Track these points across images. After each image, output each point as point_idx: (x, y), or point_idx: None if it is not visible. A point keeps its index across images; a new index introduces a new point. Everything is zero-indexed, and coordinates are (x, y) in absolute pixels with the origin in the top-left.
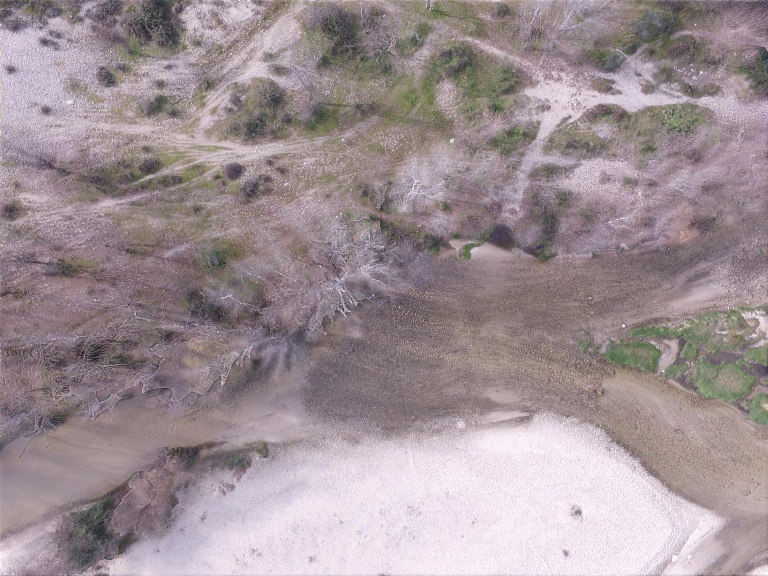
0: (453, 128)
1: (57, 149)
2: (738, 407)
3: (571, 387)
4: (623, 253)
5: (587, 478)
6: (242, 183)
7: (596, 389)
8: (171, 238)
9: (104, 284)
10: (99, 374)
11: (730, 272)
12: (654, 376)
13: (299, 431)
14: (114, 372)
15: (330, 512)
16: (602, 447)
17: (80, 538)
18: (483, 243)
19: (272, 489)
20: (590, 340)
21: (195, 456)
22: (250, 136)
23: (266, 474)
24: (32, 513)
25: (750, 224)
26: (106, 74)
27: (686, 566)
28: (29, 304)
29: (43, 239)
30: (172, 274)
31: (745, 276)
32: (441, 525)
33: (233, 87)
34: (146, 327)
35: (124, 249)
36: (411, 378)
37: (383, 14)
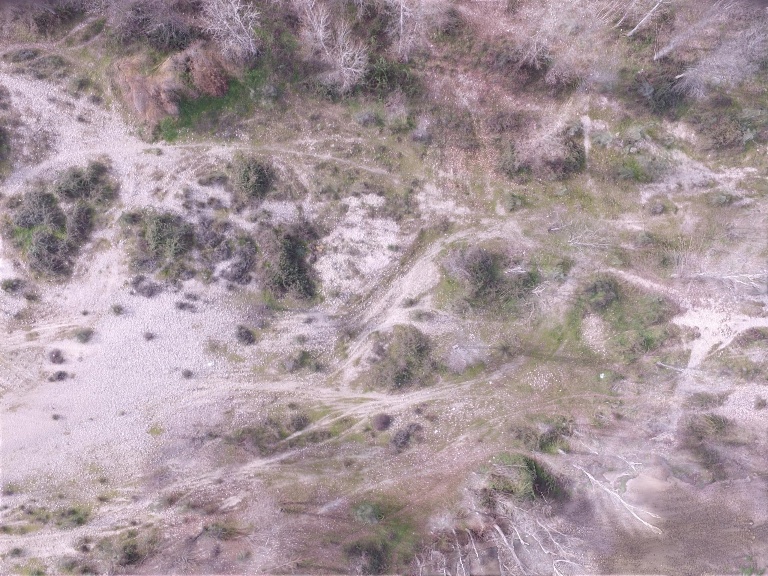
0: (602, 362)
1: (201, 413)
2: None
3: None
4: None
5: None
6: (391, 433)
7: None
8: (323, 494)
9: (259, 545)
10: None
11: None
12: None
13: None
14: None
15: None
16: None
17: None
18: (638, 474)
19: None
20: (753, 565)
21: None
22: (397, 387)
23: None
24: None
25: None
26: (246, 334)
27: None
28: (185, 570)
29: (195, 505)
30: (327, 530)
31: None
32: None
33: (375, 336)
34: None
35: (278, 511)
36: None
37: (523, 251)
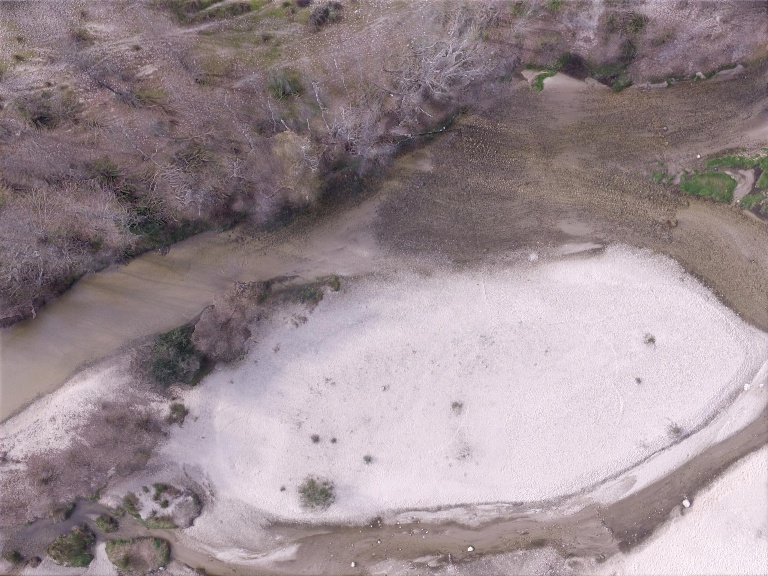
0: None
1: None
2: None
3: (644, 219)
4: (699, 82)
5: (660, 307)
6: (311, 11)
7: (670, 220)
8: (240, 68)
9: (173, 115)
10: None
11: None
12: (728, 207)
13: (370, 265)
14: (197, 176)
15: (403, 342)
16: (675, 278)
17: (162, 353)
18: (556, 73)
19: (344, 321)
20: (664, 171)
21: (266, 290)
22: None
23: (338, 307)
24: (105, 347)
25: None
26: None
27: (758, 394)
28: (98, 136)
29: (111, 69)
30: (241, 105)
31: None
32: (514, 354)
33: None
34: (216, 158)
35: (193, 78)
36: (483, 211)
37: None
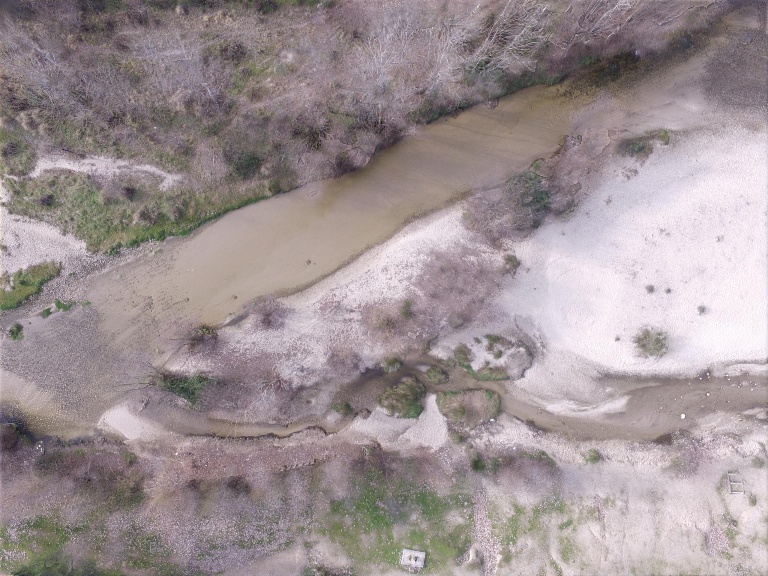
0: None
1: None
2: None
3: None
4: None
5: None
6: None
7: None
8: None
9: None
10: (506, 57)
11: None
12: None
13: (699, 119)
14: None
15: (736, 194)
16: None
17: None
18: None
19: (675, 174)
20: None
21: None
22: None
23: (668, 160)
24: (434, 199)
25: None
26: None
27: None
28: None
29: None
30: None
31: None
32: None
33: None
34: (554, 9)
35: None
36: None
37: None
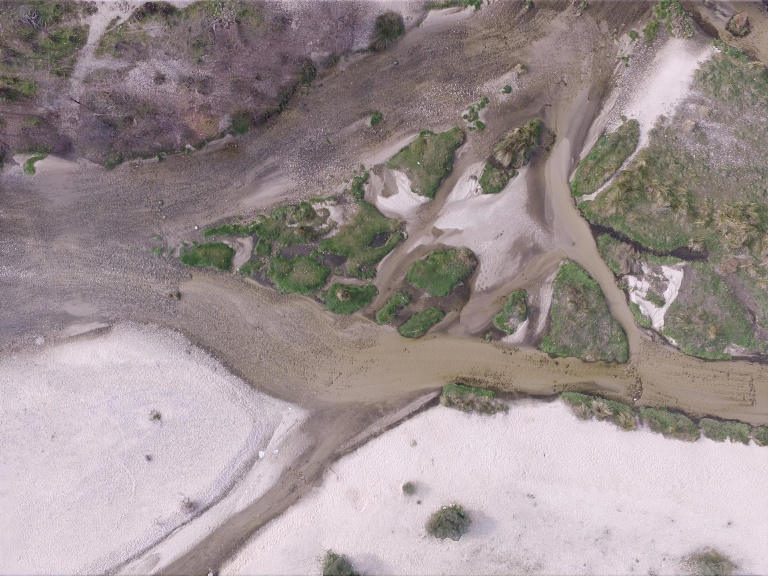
0: (0, 39)
1: None
2: (315, 299)
3: (148, 294)
4: (191, 154)
5: (165, 382)
6: None
7: (172, 293)
8: None
9: None
10: None
11: (298, 164)
12: (231, 276)
13: None
14: None
15: None
16: (182, 351)
17: None
18: (47, 156)
19: None
20: (164, 245)
21: None
22: None
23: None
24: None
25: (316, 114)
26: None
27: (273, 461)
28: None
29: None
30: None
31: (314, 167)
32: (20, 442)
33: None
34: None
35: None
36: None
37: None
